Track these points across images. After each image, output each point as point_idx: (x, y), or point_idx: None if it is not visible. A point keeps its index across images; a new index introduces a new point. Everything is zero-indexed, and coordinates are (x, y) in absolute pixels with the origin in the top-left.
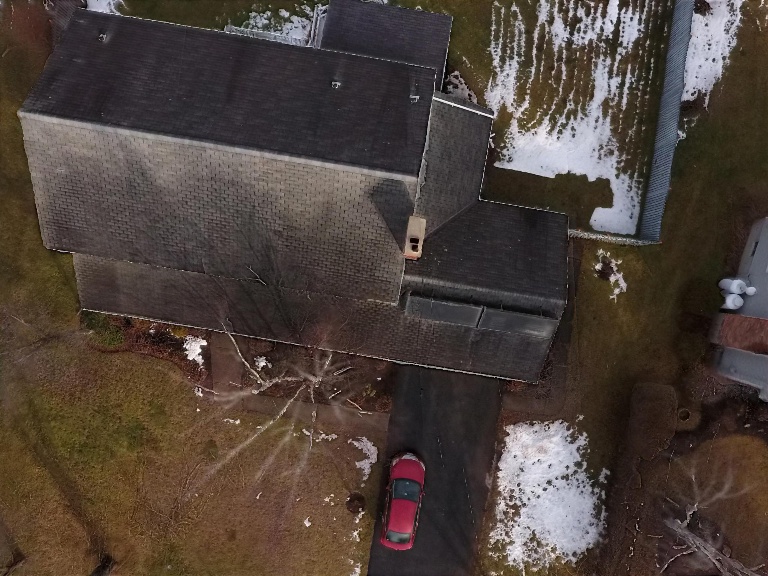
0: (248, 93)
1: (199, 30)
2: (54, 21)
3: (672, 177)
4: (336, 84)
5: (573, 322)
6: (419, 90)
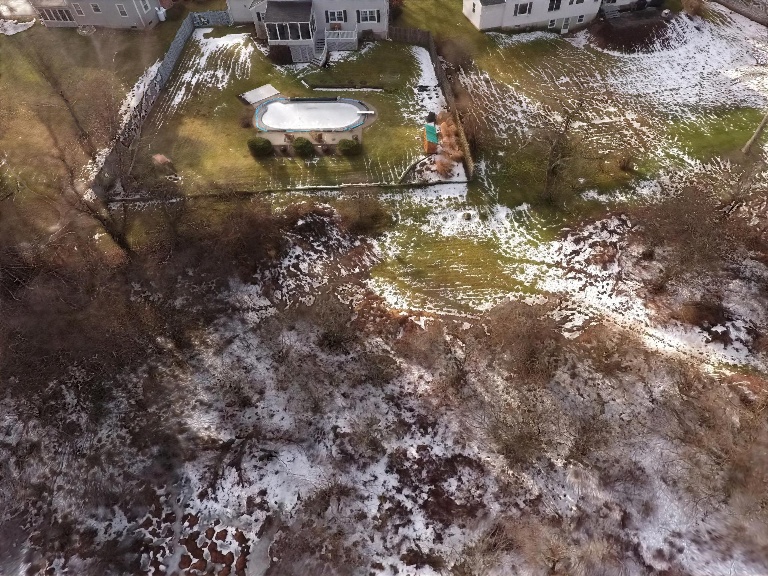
0: None
1: None
2: None
3: None
4: None
5: None
6: None
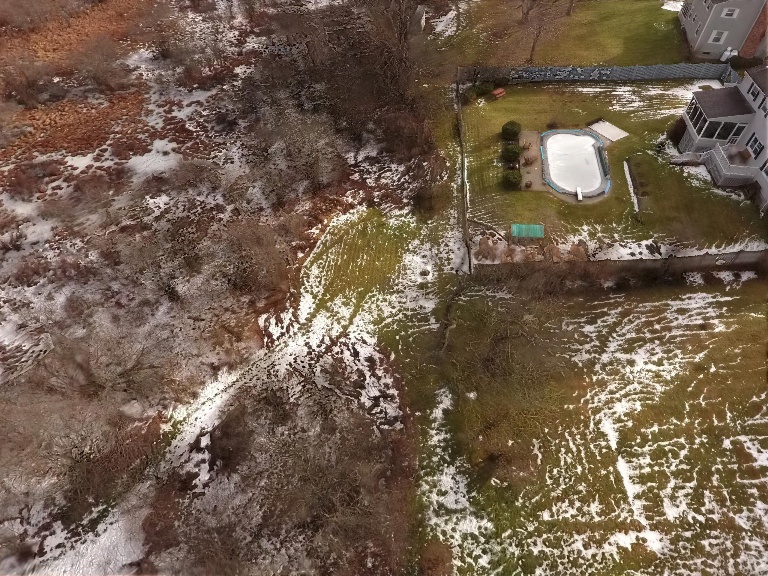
0: None
1: None
2: None
3: None
4: None
5: None
6: None
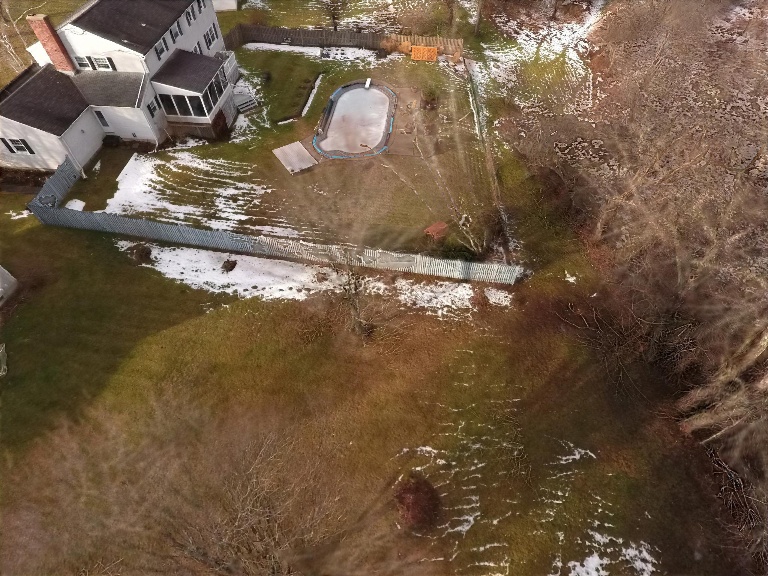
0: (146, 3)
1: (190, 4)
2: (260, 26)
3: (90, 242)
4: (143, 24)
5: (4, 192)
6: (131, 45)
